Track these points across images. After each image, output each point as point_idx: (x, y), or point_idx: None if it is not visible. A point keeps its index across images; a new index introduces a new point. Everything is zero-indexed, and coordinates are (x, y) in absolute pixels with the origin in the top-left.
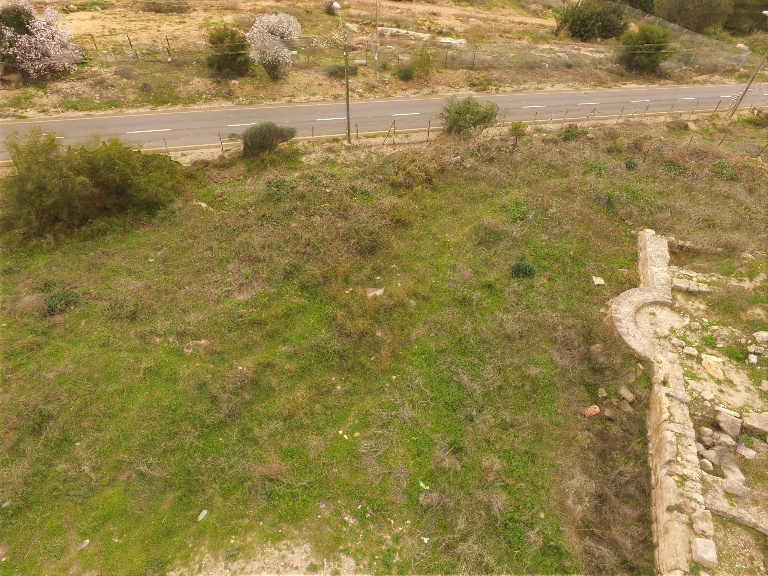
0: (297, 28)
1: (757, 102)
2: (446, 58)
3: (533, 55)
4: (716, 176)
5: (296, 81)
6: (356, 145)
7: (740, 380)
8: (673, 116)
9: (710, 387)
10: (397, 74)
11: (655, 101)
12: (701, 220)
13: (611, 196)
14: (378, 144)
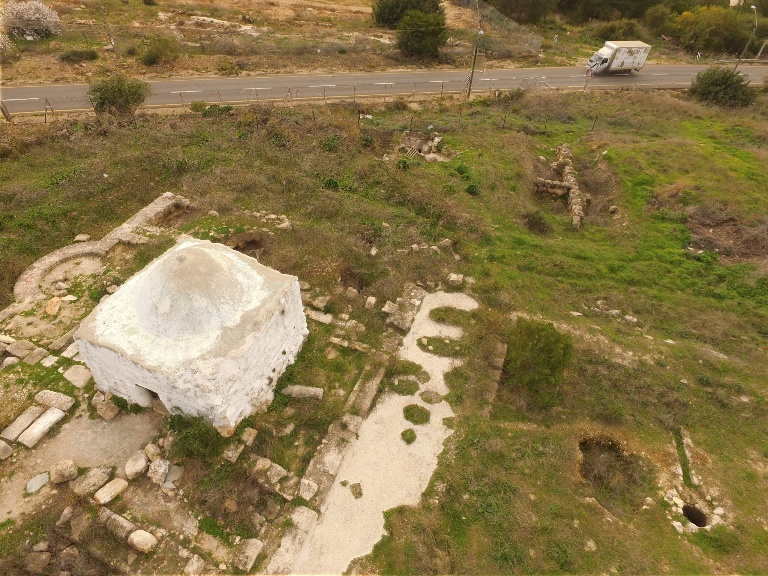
0: (52, 15)
1: (514, 85)
2: (201, 44)
3: (314, 41)
4: (322, 148)
5: (22, 65)
6: (13, 123)
7: (65, 315)
8: (399, 97)
9: (26, 321)
10: (142, 59)
11: (400, 84)
12: (228, 184)
13: (179, 164)
14: (40, 122)
